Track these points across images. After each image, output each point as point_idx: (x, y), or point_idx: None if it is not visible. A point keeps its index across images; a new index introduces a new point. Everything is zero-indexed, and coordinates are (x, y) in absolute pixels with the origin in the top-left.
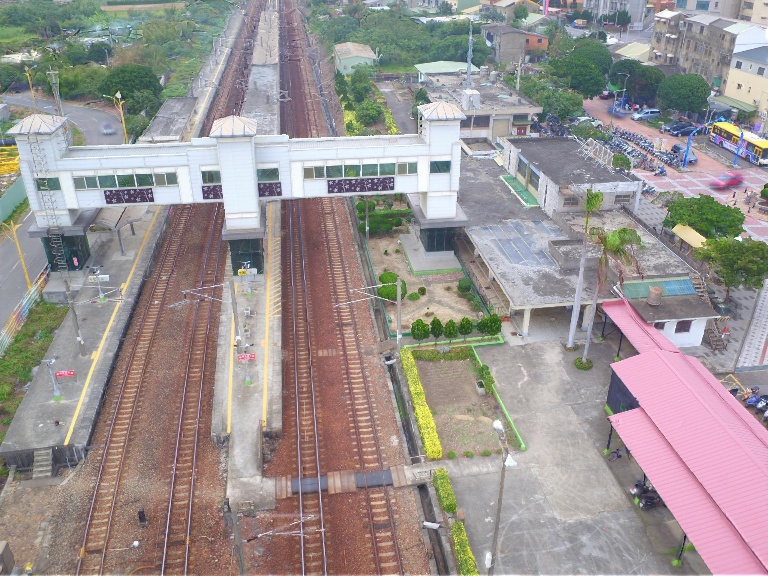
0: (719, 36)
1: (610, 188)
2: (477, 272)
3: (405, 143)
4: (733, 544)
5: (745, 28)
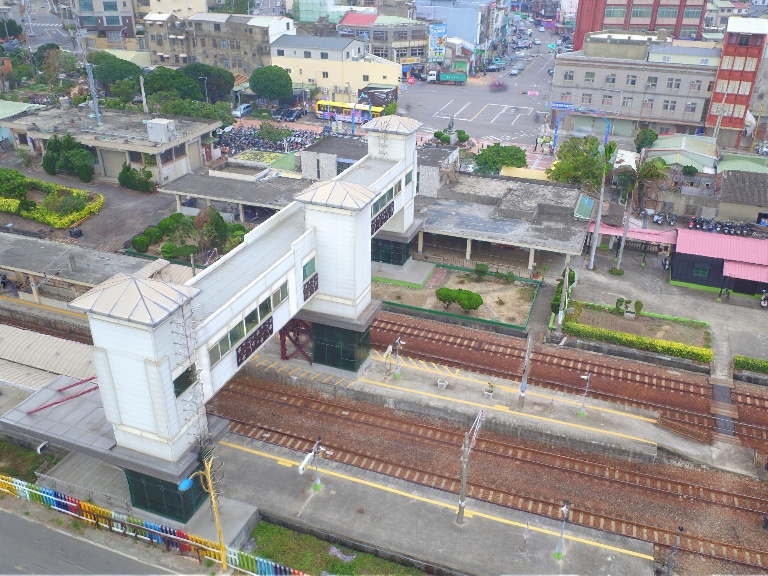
0: (244, 31)
1: (451, 158)
2: None
3: (380, 165)
4: None
5: (268, 21)
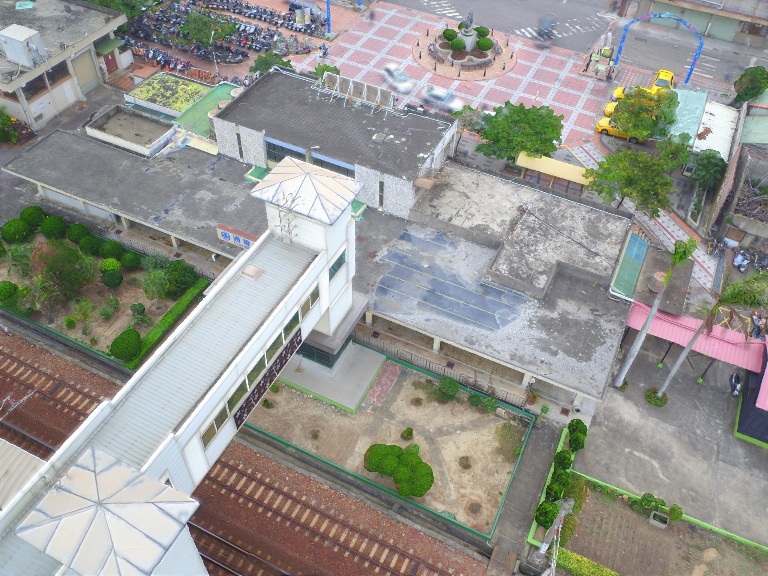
0: None
1: (441, 147)
2: (406, 349)
3: (279, 266)
4: None
5: None
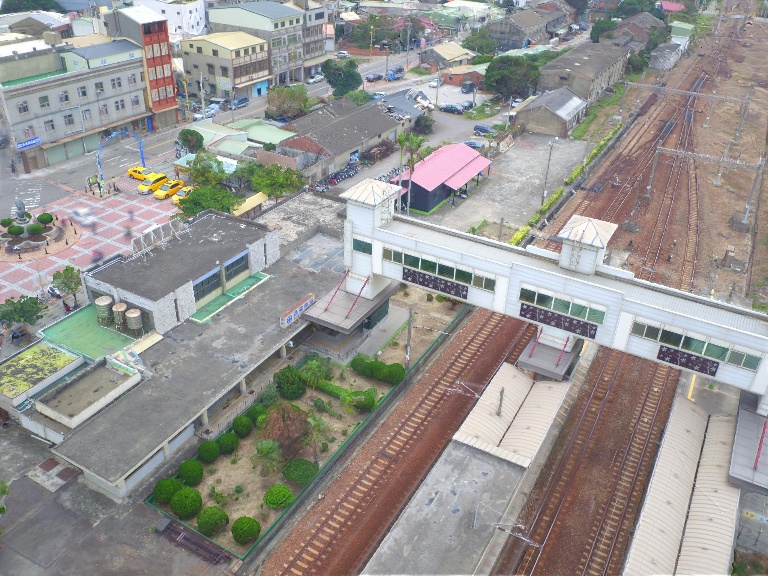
0: None
1: None
2: None
3: (403, 229)
4: (476, 162)
5: None
